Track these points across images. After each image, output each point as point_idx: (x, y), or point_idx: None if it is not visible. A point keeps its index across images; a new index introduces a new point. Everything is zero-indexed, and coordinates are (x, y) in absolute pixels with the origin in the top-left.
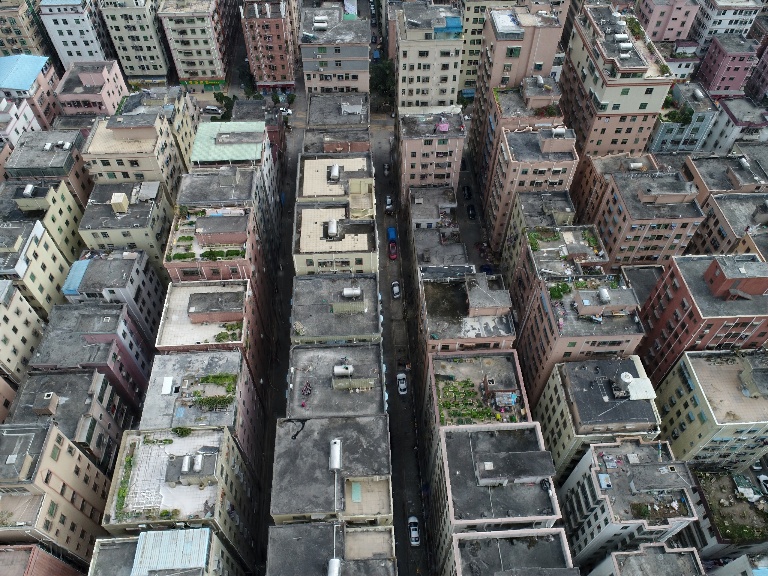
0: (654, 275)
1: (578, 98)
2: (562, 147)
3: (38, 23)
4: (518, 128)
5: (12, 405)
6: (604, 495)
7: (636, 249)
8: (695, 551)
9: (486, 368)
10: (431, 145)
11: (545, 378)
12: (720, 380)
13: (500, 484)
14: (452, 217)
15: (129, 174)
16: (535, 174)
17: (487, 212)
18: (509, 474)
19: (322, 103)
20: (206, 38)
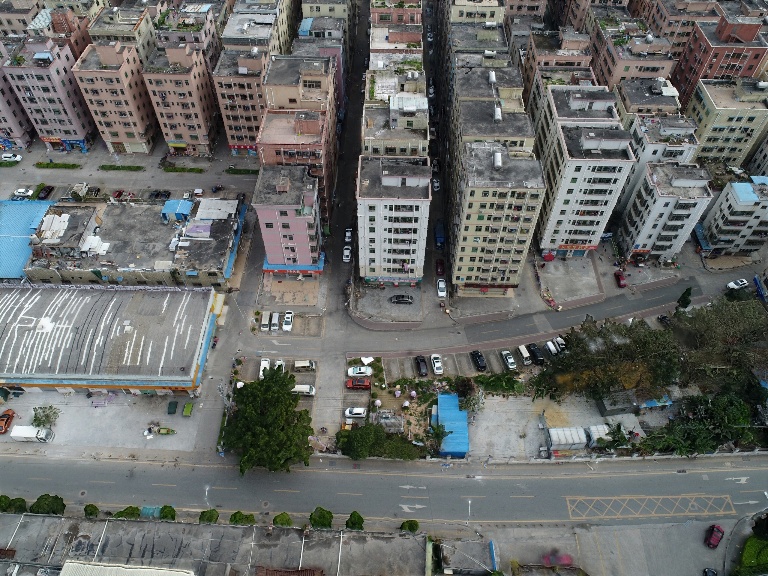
0: None
1: None
2: None
3: None
4: None
5: None
6: (643, 133)
7: None
8: (697, 165)
9: None
10: None
11: None
12: (721, 94)
13: (584, 109)
14: None
15: None
16: None
17: None
18: (590, 99)
19: None
20: None
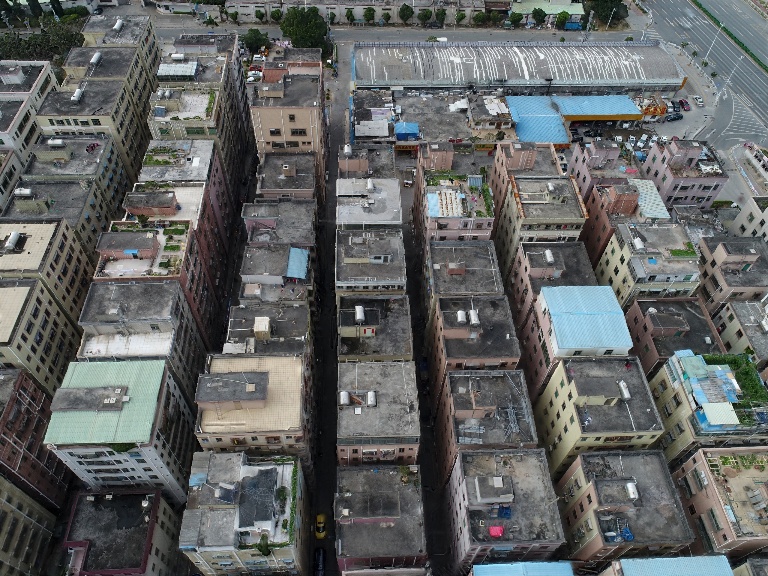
0: None
1: None
2: None
3: None
4: None
5: None
6: None
7: None
8: None
9: None
10: None
11: None
12: None
13: None
14: None
15: None
16: None
17: None
18: None
19: None
20: None
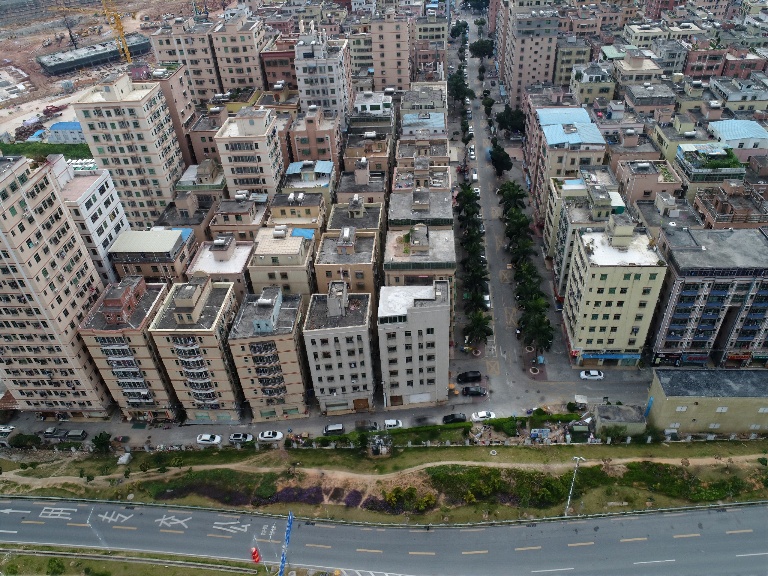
0: None
1: None
2: None
3: None
4: None
5: None
6: None
7: None
8: None
9: None
10: None
11: None
12: None
13: None
14: None
15: None
16: None
17: None
18: None
19: None
20: None
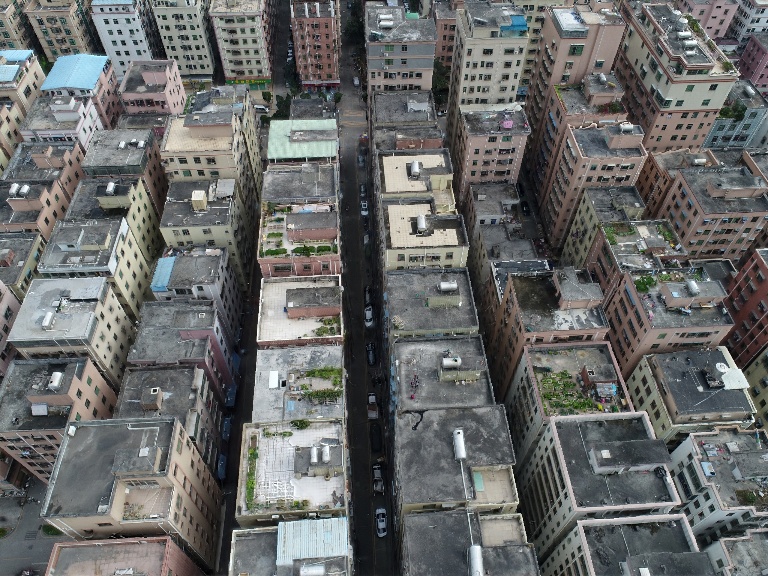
0: (721, 269)
1: (636, 95)
2: (629, 143)
3: (86, 23)
4: (582, 125)
5: (118, 400)
6: (710, 482)
7: (704, 243)
8: None
9: (581, 360)
10: (495, 142)
11: (629, 370)
12: None
13: (615, 472)
14: (514, 213)
15: (205, 172)
16: (603, 170)
17: (545, 208)
18: (627, 462)
19: (387, 101)
20: (255, 37)
